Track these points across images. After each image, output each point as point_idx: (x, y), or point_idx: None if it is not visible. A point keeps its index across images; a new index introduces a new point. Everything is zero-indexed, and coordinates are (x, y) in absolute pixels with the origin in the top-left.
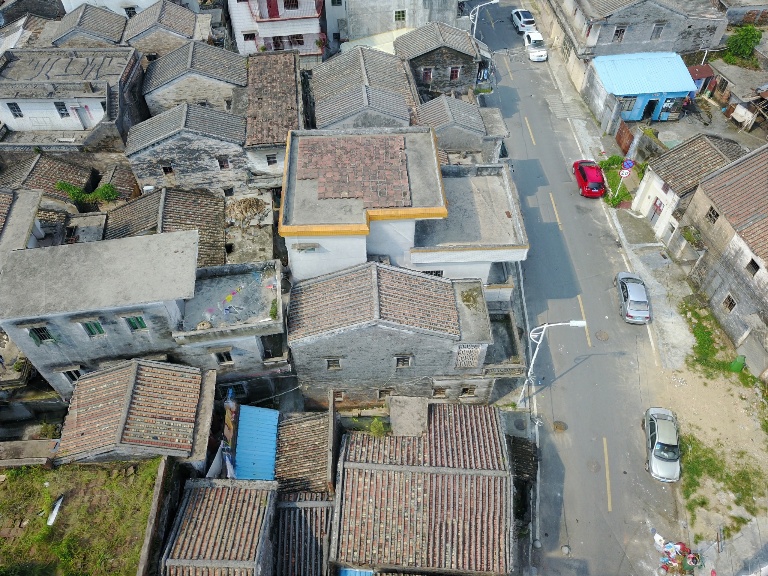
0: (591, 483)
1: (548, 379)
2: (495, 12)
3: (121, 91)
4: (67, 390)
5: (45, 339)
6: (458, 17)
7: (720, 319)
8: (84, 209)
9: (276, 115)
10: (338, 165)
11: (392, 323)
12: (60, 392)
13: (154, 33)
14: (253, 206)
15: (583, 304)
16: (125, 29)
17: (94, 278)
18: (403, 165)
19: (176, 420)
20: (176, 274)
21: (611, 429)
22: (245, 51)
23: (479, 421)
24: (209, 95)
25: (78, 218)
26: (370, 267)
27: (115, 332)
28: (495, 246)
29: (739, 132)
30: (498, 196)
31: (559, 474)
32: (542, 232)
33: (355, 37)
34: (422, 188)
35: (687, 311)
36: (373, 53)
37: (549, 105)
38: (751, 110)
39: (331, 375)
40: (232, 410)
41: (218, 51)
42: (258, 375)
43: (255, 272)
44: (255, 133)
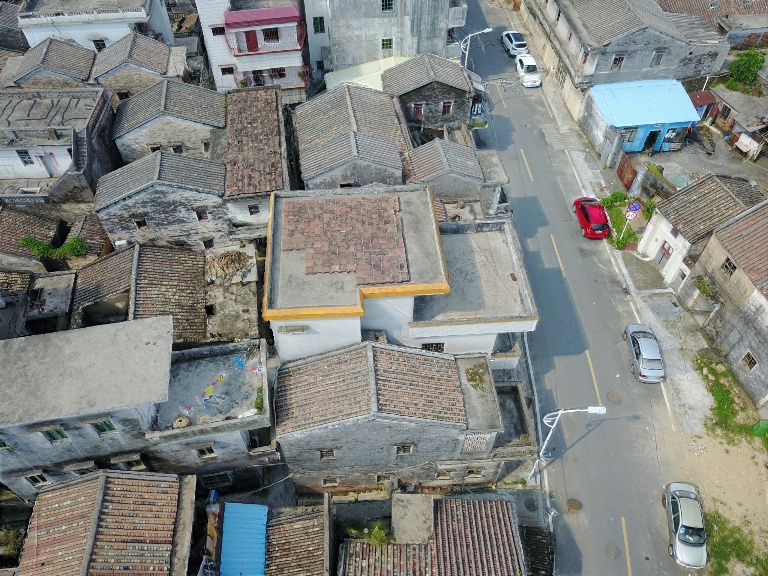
0: (611, 572)
1: (559, 450)
2: (485, 34)
3: (89, 137)
4: (30, 492)
5: (0, 447)
6: (448, 44)
7: (739, 376)
8: (51, 265)
9: (258, 160)
10: (327, 232)
11: (392, 416)
12: (22, 494)
13: (124, 70)
14: (235, 261)
15: (592, 361)
16: (93, 65)
17: (54, 379)
18: (399, 231)
19: (150, 542)
20: (147, 372)
21: (629, 507)
22: (223, 88)
23: (491, 521)
24: (185, 137)
25: (44, 278)
26: (365, 348)
27: (80, 436)
28: (501, 318)
29: (744, 162)
30: (501, 255)
31: (576, 562)
32: (544, 279)
33: (340, 67)
34: (420, 258)
35: (703, 367)
36: (360, 90)
37: (545, 135)
38: (756, 139)
39: (325, 464)
40: (215, 513)
41: (194, 89)
42: (244, 465)
43: (238, 352)
44: (235, 182)
